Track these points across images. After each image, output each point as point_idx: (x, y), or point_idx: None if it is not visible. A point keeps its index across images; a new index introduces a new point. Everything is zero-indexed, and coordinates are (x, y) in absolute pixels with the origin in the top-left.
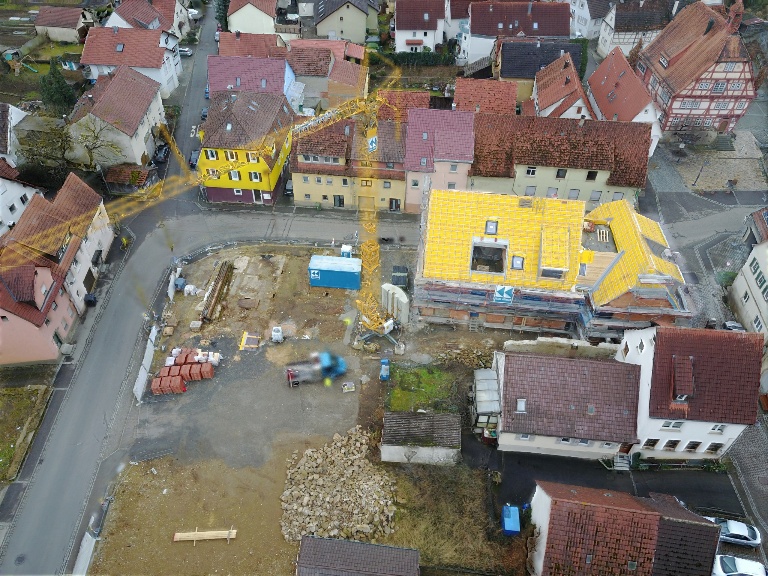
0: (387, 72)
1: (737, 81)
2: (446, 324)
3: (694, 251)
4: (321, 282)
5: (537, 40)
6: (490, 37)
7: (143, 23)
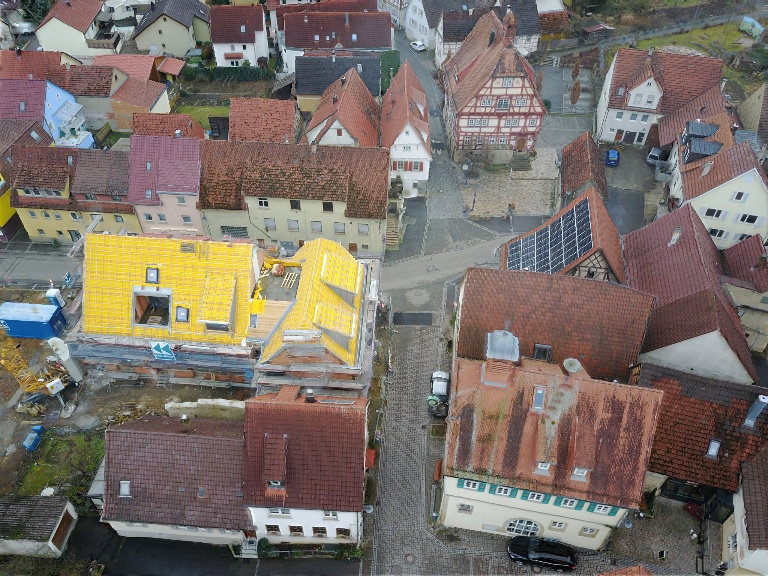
0: (201, 88)
1: (521, 97)
2: (133, 380)
3: (443, 287)
4: (15, 332)
5: (331, 54)
6: None
7: None
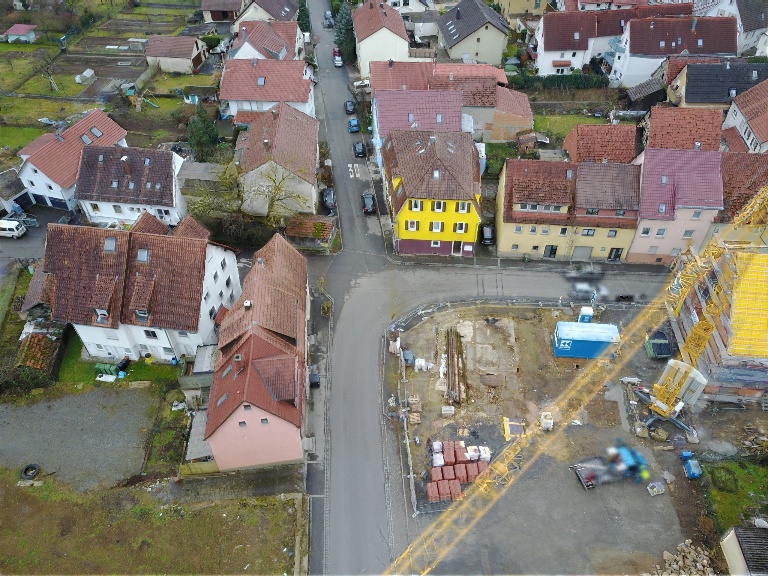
0: (536, 97)
1: None
2: (733, 402)
3: None
4: (568, 352)
5: (727, 61)
6: (651, 56)
7: (274, 52)
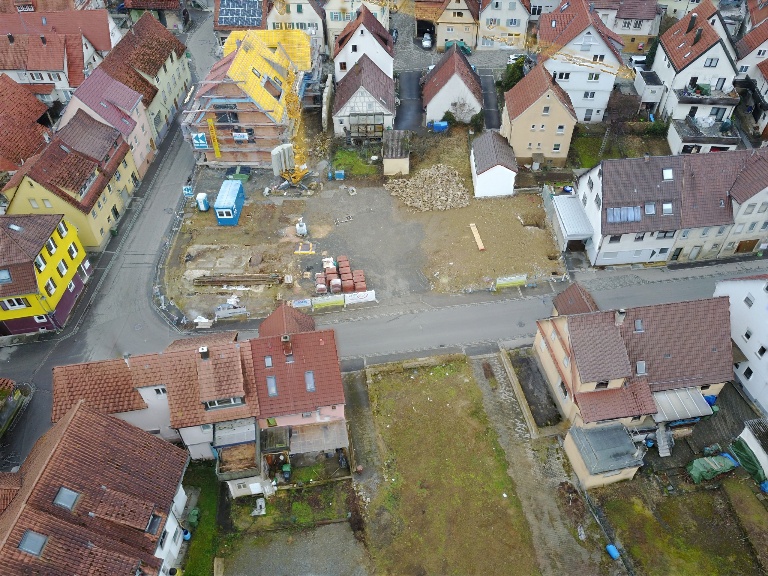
0: None
1: None
2: None
3: None
4: None
5: None
6: None
7: None
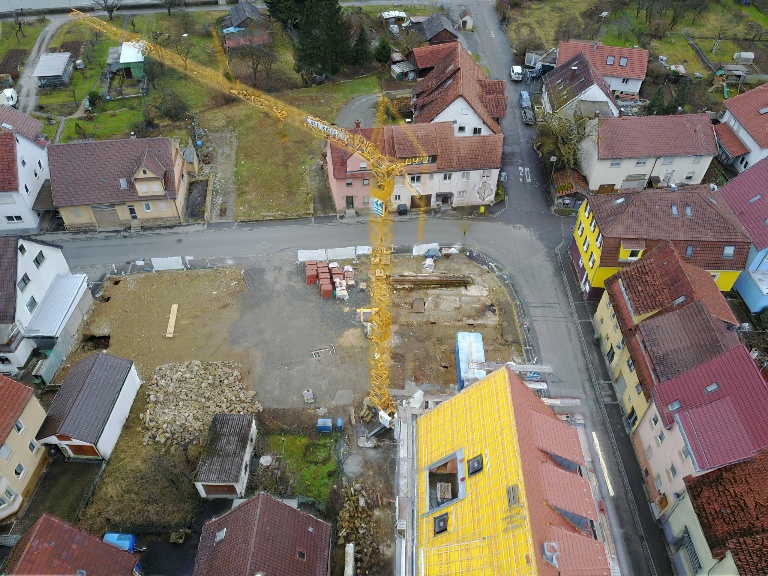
0: None
1: None
2: None
3: None
4: None
5: None
6: None
7: None
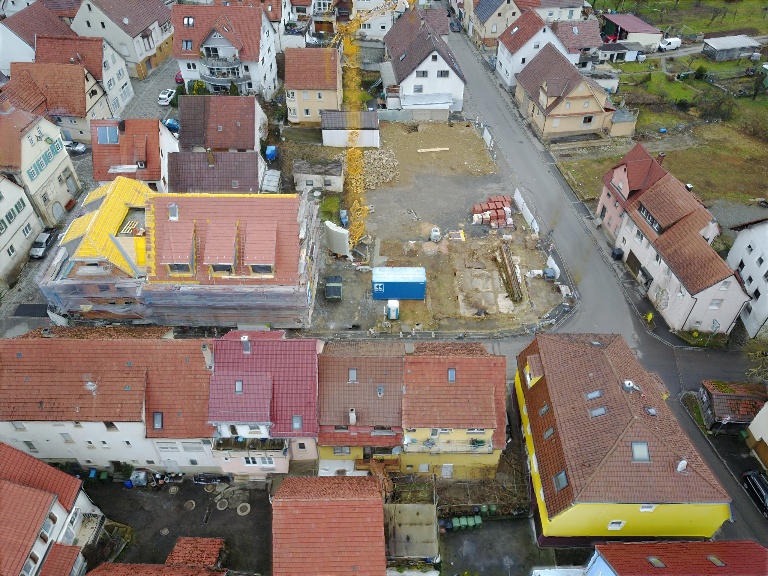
0: None
1: None
2: None
3: None
4: None
5: None
6: None
7: None
